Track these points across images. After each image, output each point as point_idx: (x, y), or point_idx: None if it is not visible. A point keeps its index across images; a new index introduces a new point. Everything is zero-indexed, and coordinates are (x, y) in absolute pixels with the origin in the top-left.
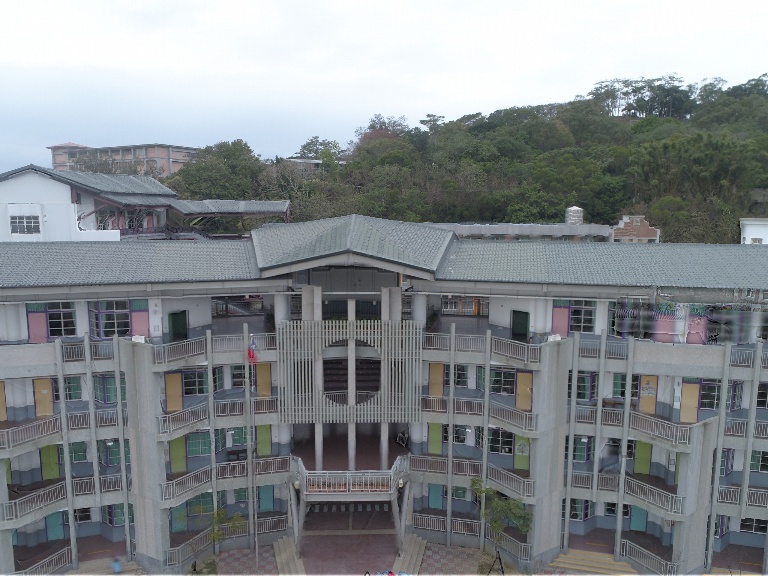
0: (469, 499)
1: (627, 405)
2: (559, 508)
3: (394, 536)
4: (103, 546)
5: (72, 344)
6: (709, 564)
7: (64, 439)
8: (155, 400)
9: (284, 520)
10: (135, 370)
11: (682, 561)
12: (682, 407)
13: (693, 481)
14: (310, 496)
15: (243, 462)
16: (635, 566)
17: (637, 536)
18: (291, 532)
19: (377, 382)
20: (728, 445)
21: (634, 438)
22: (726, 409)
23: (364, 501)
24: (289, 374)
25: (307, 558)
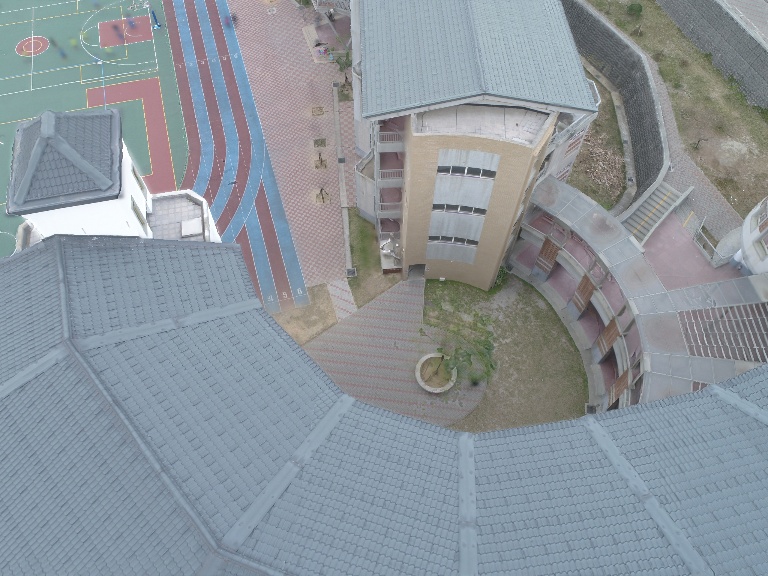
0: None
1: None
2: None
3: None
4: None
5: None
6: None
7: None
8: None
9: None
10: None
11: None
12: None
13: (356, 104)
14: None
15: None
16: None
17: None
18: None
19: None
20: None
21: None
22: None
23: (313, 4)
24: None
25: None
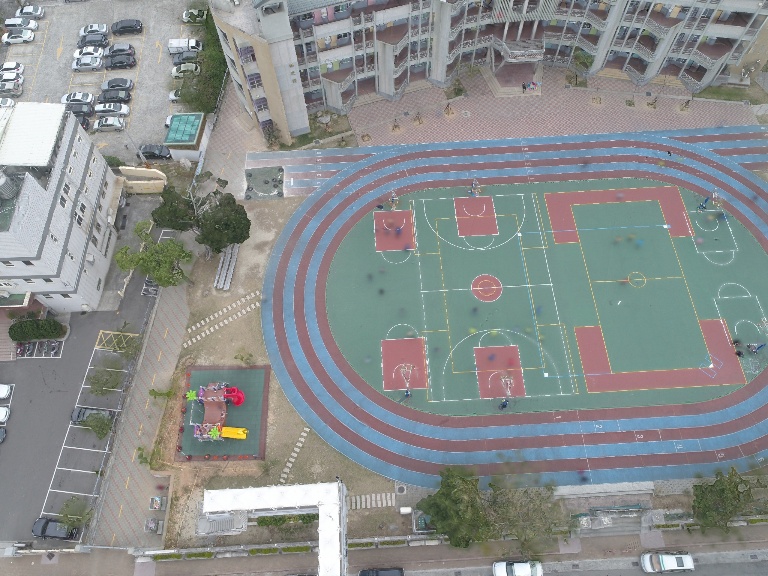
0: (564, 45)
1: (648, 16)
2: (605, 54)
3: (531, 64)
4: (412, 75)
5: (415, 4)
6: (658, 74)
7: (409, 41)
8: (449, 25)
9: (484, 60)
10: (441, 13)
11: (647, 75)
12: (672, 12)
13: (663, 48)
14: (510, 60)
15: (473, 40)
16: (629, 75)
17: (634, 60)
18: (487, 65)
19: (537, 2)
20: (683, 32)
21: (646, 29)
22: (689, 15)
23: None
24: (499, 3)
25: (498, 77)
